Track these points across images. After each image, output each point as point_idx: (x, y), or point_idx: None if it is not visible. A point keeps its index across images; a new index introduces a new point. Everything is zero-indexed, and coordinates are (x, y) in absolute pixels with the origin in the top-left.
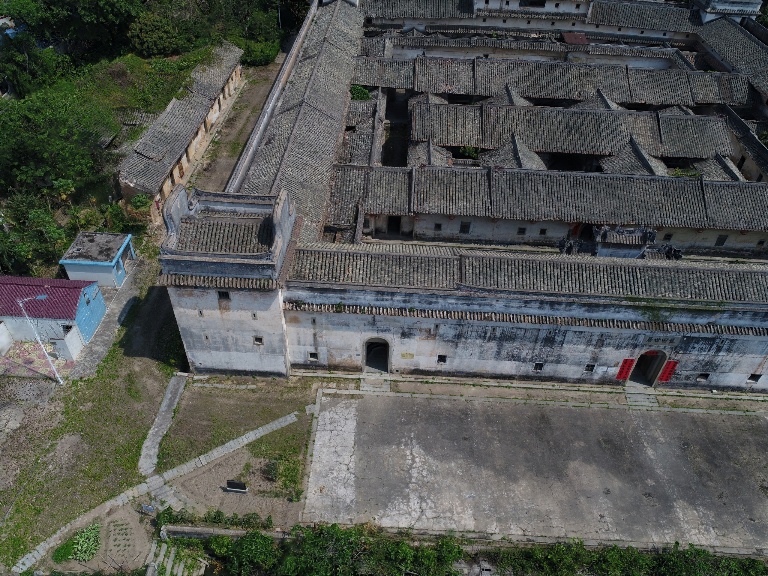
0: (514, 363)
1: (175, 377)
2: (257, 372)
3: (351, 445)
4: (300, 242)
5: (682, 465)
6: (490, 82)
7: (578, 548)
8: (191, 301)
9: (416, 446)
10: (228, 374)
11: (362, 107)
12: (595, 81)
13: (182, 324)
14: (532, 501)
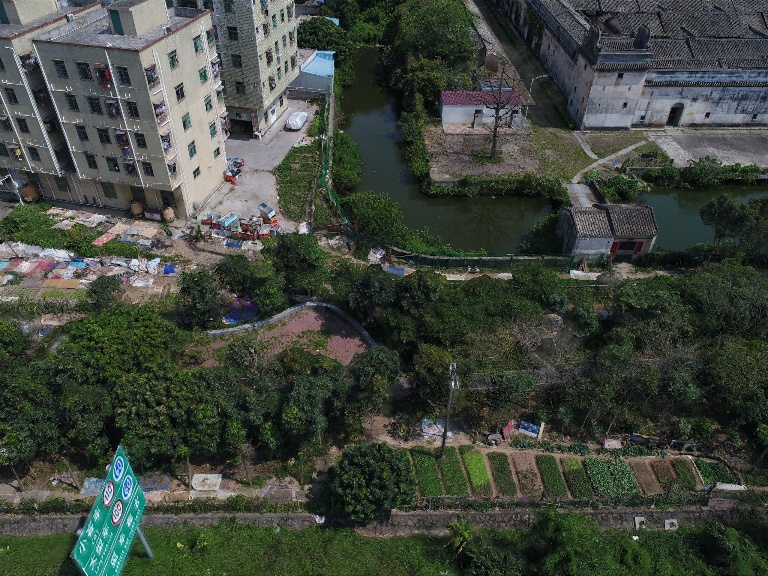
0: (743, 115)
1: (574, 132)
2: (615, 128)
3: (680, 148)
4: None
5: None
6: (647, 4)
7: None
8: (603, 81)
9: (711, 147)
10: (599, 130)
11: None
12: (711, 1)
13: (591, 96)
14: None
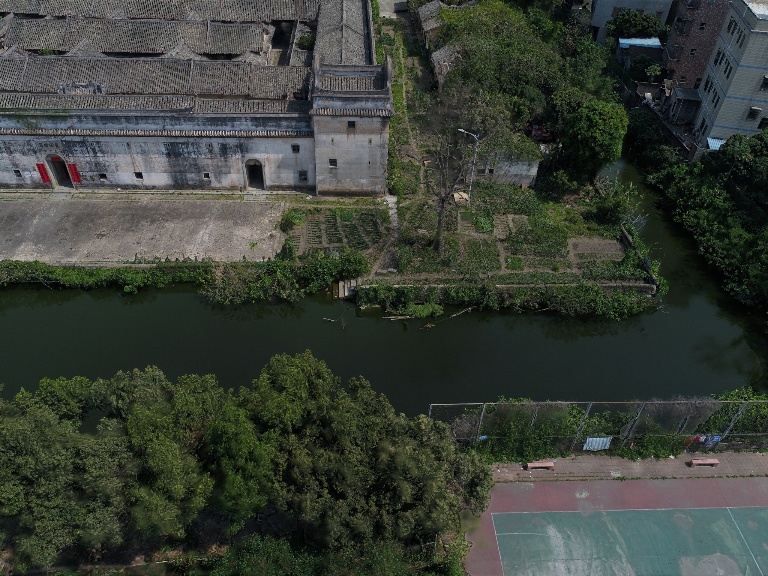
0: None
1: None
2: None
3: None
4: None
5: (52, 226)
6: (105, 7)
7: None
8: None
9: None
10: None
11: None
12: (193, 5)
13: None
14: None
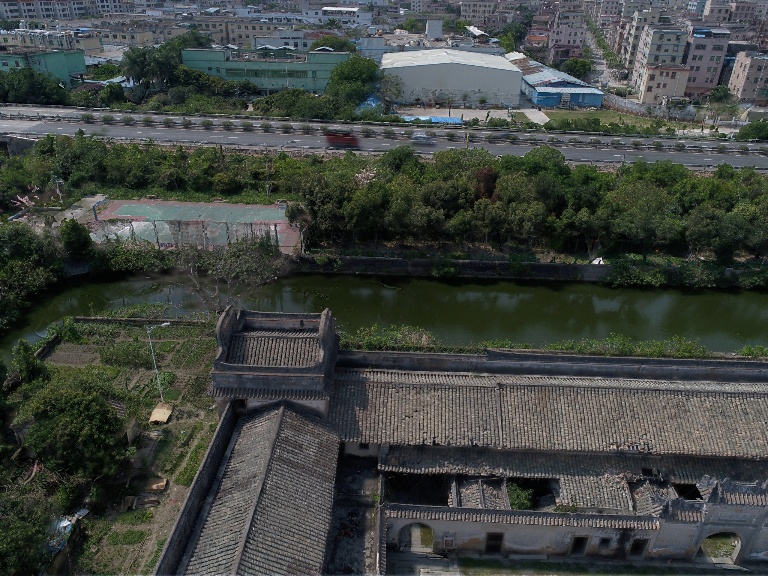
0: None
1: None
2: None
3: None
4: None
5: None
6: None
7: (678, 353)
8: None
9: None
10: None
11: None
12: None
13: None
14: None
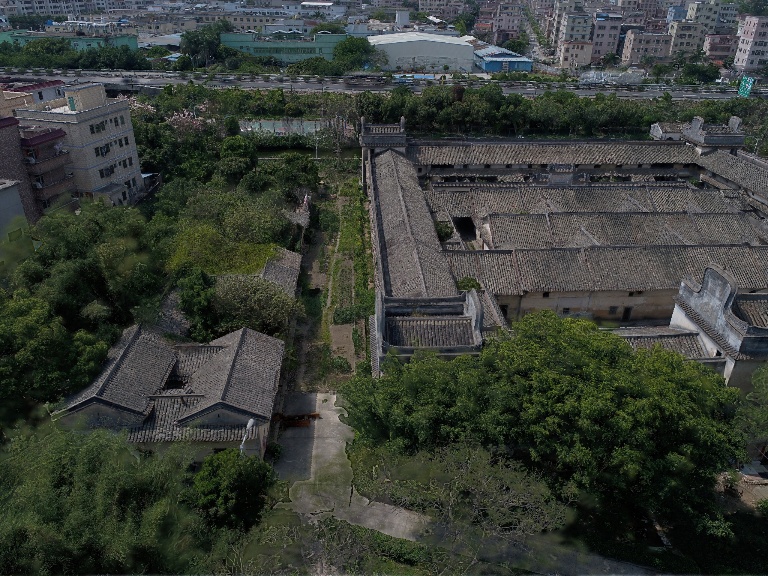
0: None
1: None
2: None
3: None
4: (698, 156)
5: None
6: None
7: None
8: None
9: None
10: None
11: None
12: None
13: None
14: None
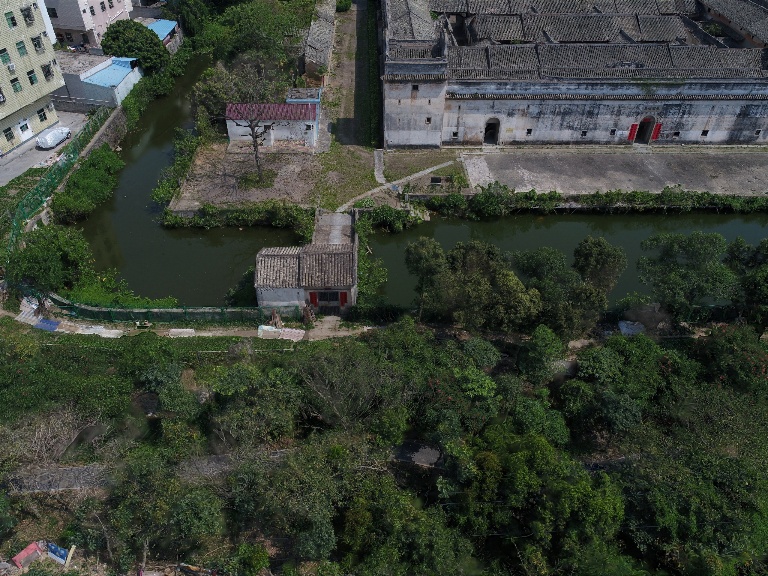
0: (570, 132)
1: (376, 151)
2: (423, 146)
3: (487, 170)
4: None
5: (668, 170)
6: (520, 5)
7: None
8: (396, 93)
9: (523, 169)
10: (406, 149)
11: (436, 24)
12: (592, 2)
13: (387, 111)
14: (591, 184)
